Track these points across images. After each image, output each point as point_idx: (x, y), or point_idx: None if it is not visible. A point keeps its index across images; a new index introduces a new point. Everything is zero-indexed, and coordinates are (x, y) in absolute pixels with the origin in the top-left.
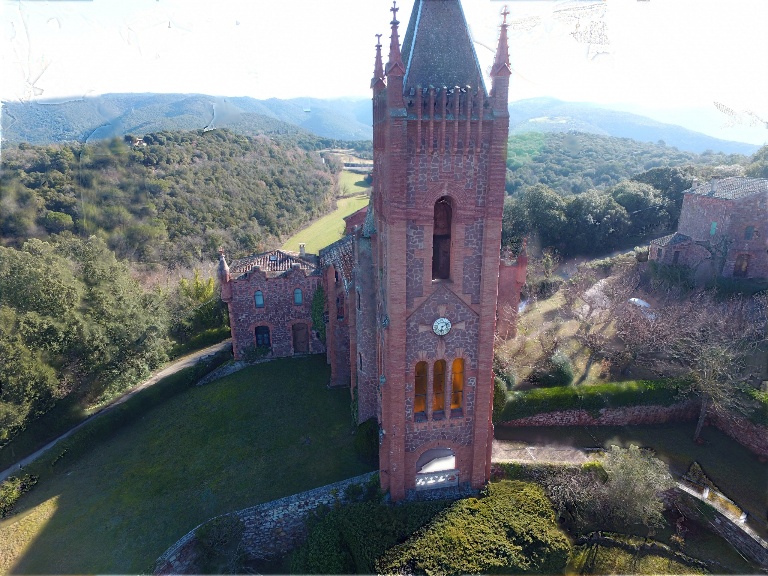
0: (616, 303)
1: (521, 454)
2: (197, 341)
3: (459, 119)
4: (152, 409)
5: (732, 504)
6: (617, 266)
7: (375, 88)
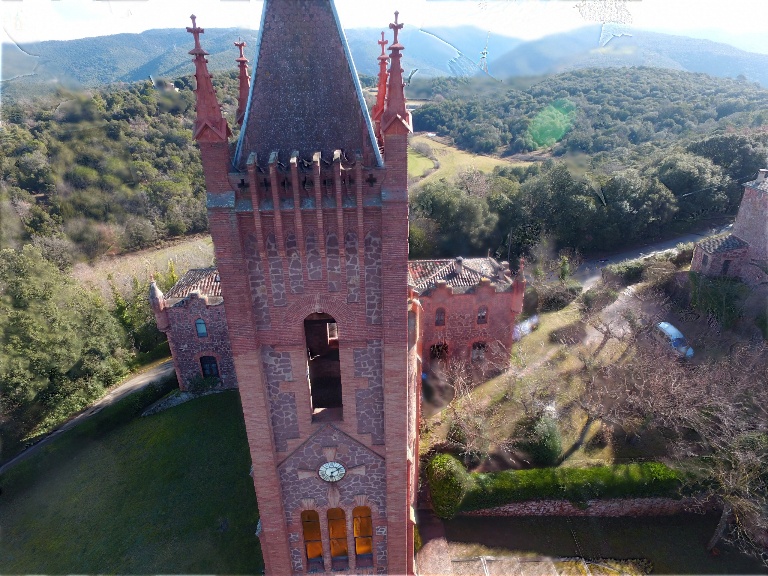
0: (638, 332)
1: (473, 569)
2: (163, 348)
3: (323, 207)
4: (87, 446)
5: None
6: (650, 272)
7: None
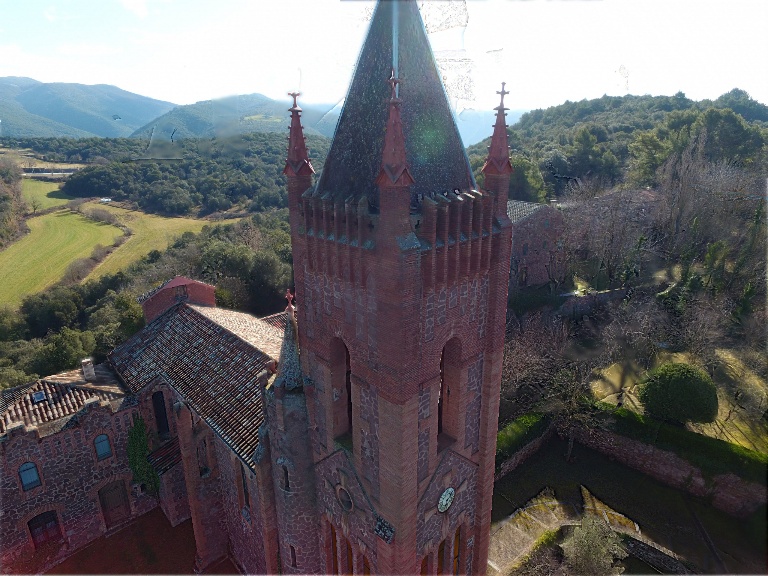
0: None
1: None
2: None
3: (471, 238)
4: None
5: (624, 518)
6: None
7: (298, 176)
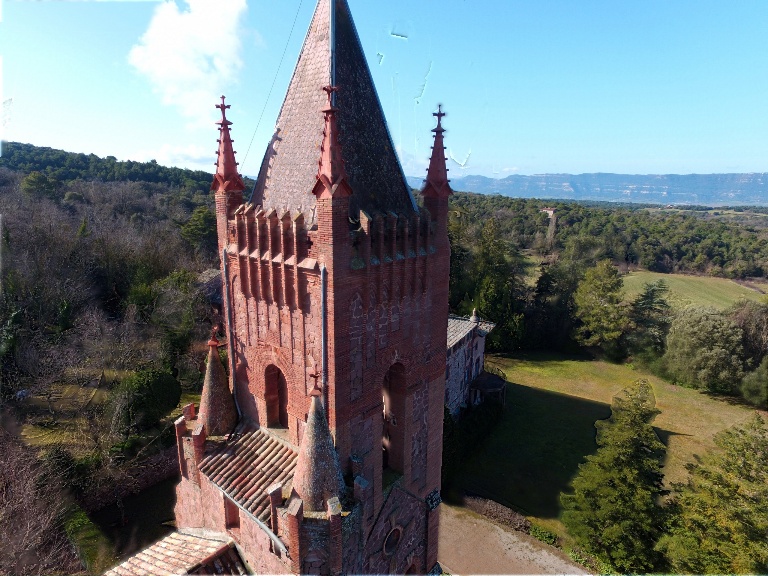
0: None
1: None
2: None
3: None
4: None
5: None
6: None
7: (347, 196)
